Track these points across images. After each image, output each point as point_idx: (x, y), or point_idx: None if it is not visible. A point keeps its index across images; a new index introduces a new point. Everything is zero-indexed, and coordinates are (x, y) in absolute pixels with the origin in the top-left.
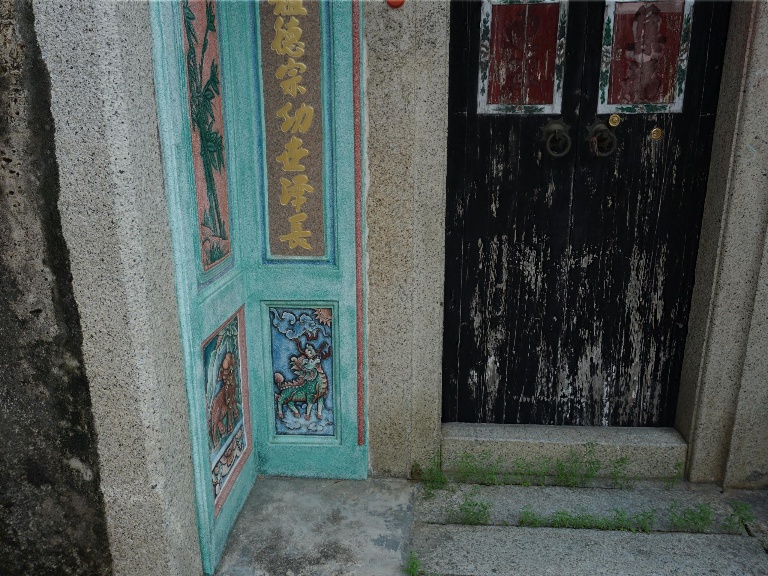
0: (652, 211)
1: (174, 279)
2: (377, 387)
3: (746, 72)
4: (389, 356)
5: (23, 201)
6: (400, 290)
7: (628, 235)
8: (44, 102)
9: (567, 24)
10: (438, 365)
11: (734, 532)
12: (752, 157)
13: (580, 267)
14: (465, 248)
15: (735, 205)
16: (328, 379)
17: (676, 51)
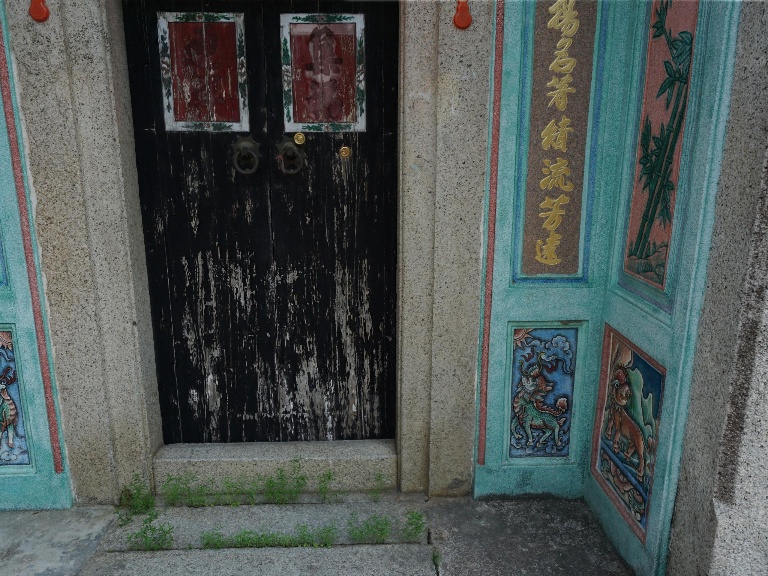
0: (349, 227)
1: None
2: (71, 411)
3: (403, 94)
4: (80, 379)
5: None
6: (83, 310)
7: (329, 251)
8: None
9: (245, 43)
10: (137, 386)
11: (414, 541)
12: (417, 175)
13: (287, 283)
14: (170, 266)
15: (407, 221)
16: (16, 405)
17: (353, 72)
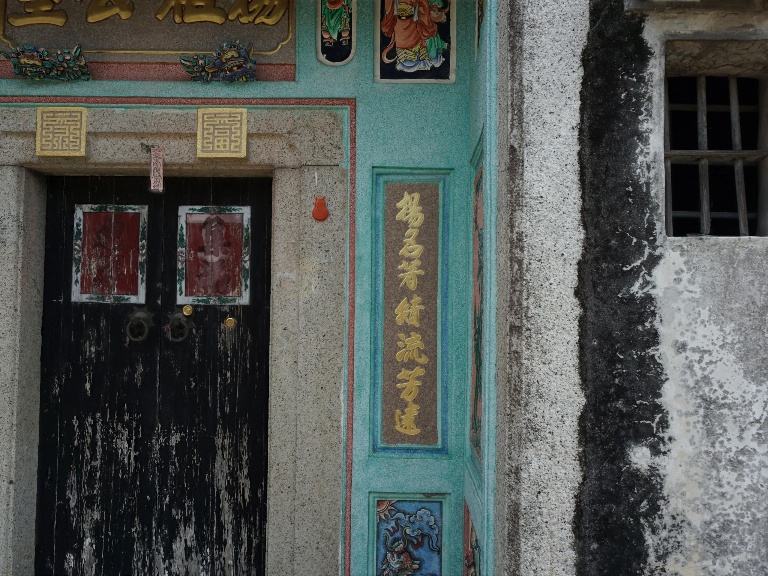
0: (231, 392)
1: None
2: None
3: None
4: None
5: None
6: None
7: (212, 415)
8: None
9: (147, 229)
10: (5, 548)
11: None
12: (283, 346)
13: (169, 445)
14: (61, 425)
15: (274, 389)
16: None
17: (240, 254)
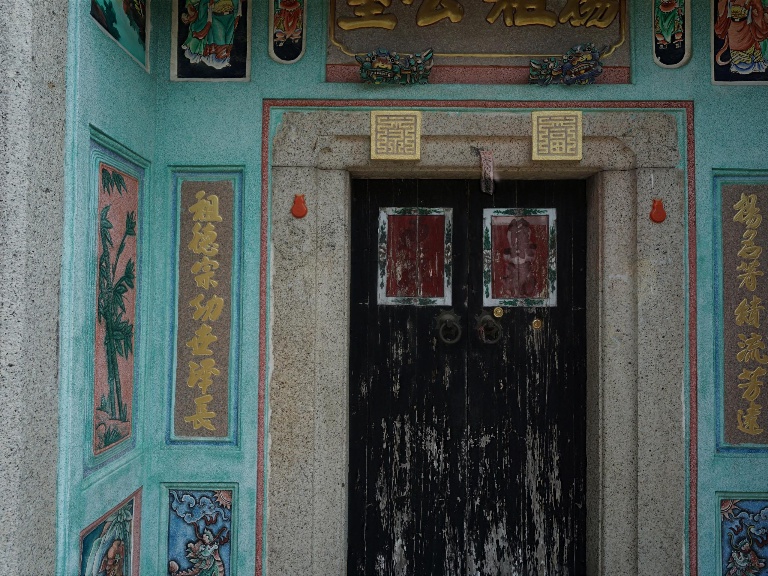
0: (540, 393)
1: (56, 465)
2: (276, 575)
3: (601, 275)
4: (289, 541)
5: None
6: (301, 471)
7: (521, 416)
8: None
9: (452, 232)
10: (340, 550)
11: None
12: (616, 347)
13: (479, 447)
14: (369, 428)
15: (608, 390)
16: (225, 567)
17: (546, 256)
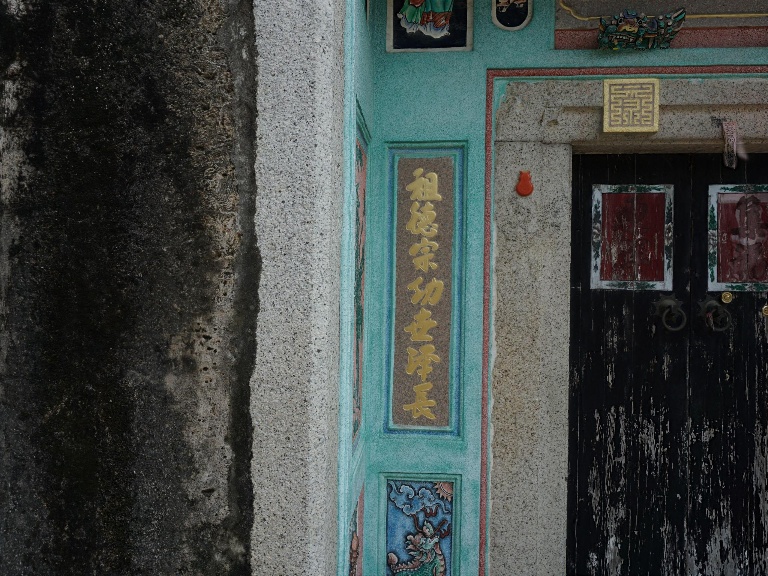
0: None
1: (337, 456)
2: (499, 572)
3: None
4: (513, 536)
5: (216, 377)
6: (525, 464)
7: (749, 409)
8: (253, 284)
9: (673, 211)
10: (563, 547)
11: None
12: None
13: (702, 441)
14: (581, 419)
15: None
16: (446, 561)
17: None
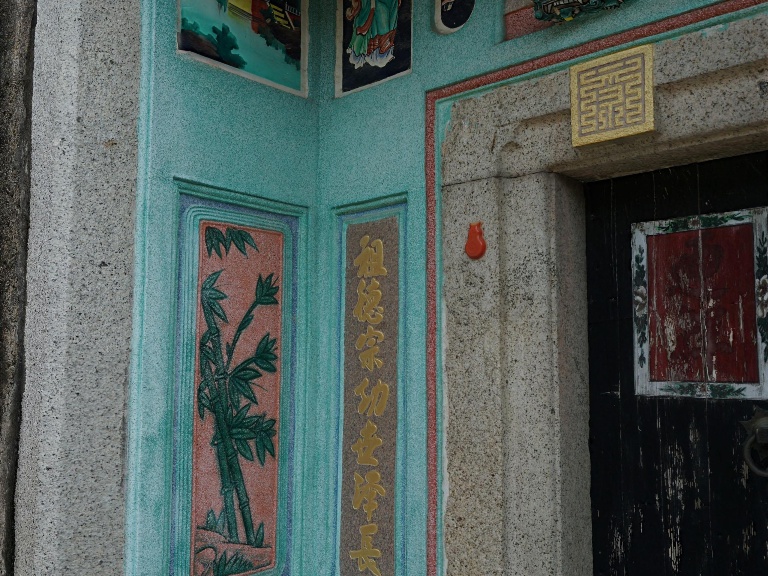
0: None
1: None
2: None
3: None
4: None
5: None
6: None
7: None
8: (20, 395)
9: None
10: None
11: None
12: None
13: None
14: None
15: None
16: None
17: None
